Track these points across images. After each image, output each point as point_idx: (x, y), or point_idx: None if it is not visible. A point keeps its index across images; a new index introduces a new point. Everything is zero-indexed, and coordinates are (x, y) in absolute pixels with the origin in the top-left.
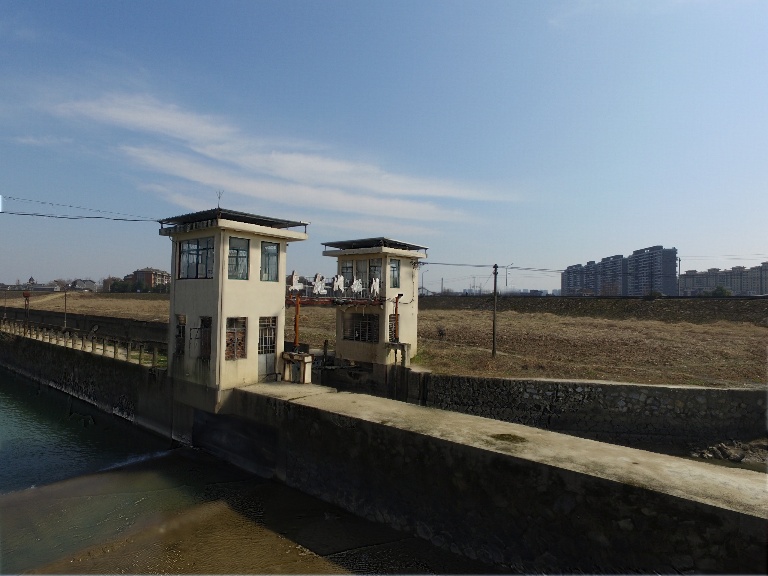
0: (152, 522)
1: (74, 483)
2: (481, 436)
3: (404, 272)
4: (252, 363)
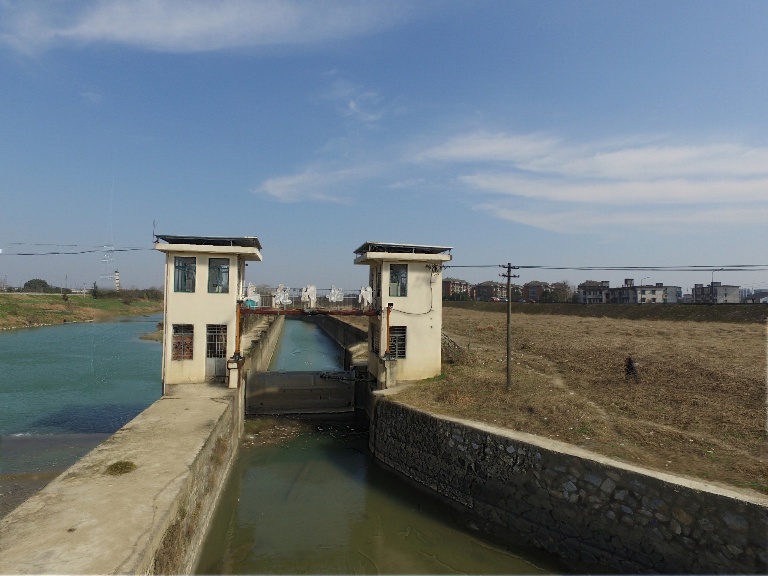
0: (48, 471)
1: (86, 436)
2: (115, 459)
3: (415, 278)
4: (199, 364)
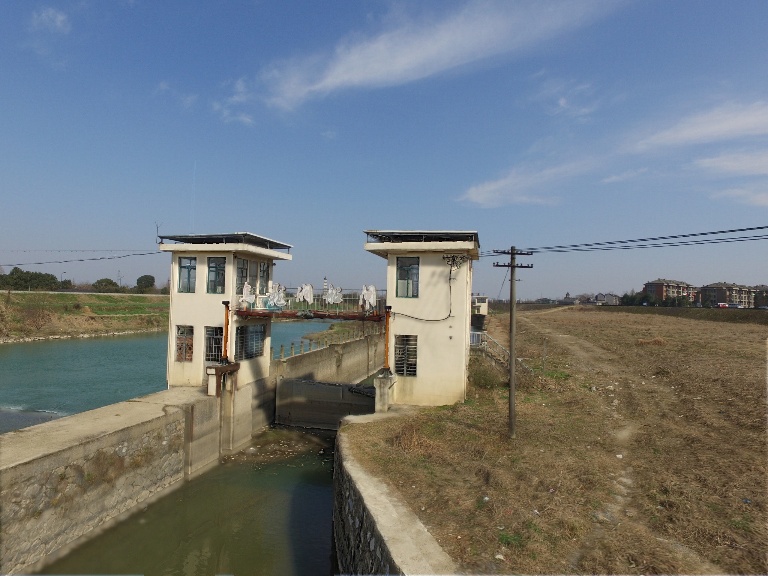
0: None
1: None
2: None
3: (429, 274)
4: (197, 367)
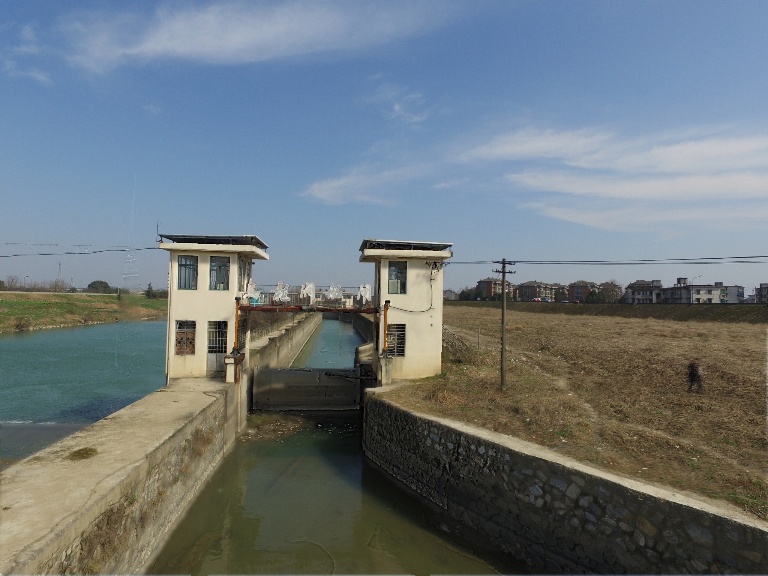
0: None
1: None
2: (82, 446)
3: (415, 275)
4: (200, 359)
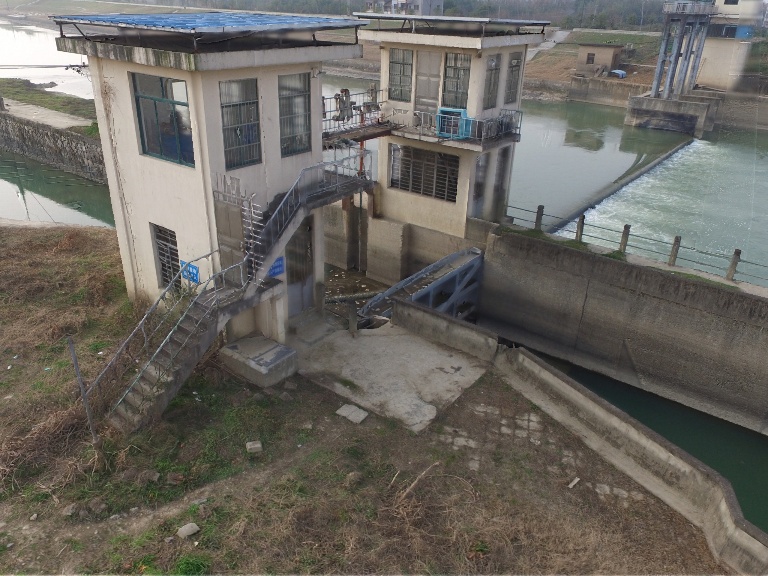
0: None
1: None
2: None
3: None
4: None
